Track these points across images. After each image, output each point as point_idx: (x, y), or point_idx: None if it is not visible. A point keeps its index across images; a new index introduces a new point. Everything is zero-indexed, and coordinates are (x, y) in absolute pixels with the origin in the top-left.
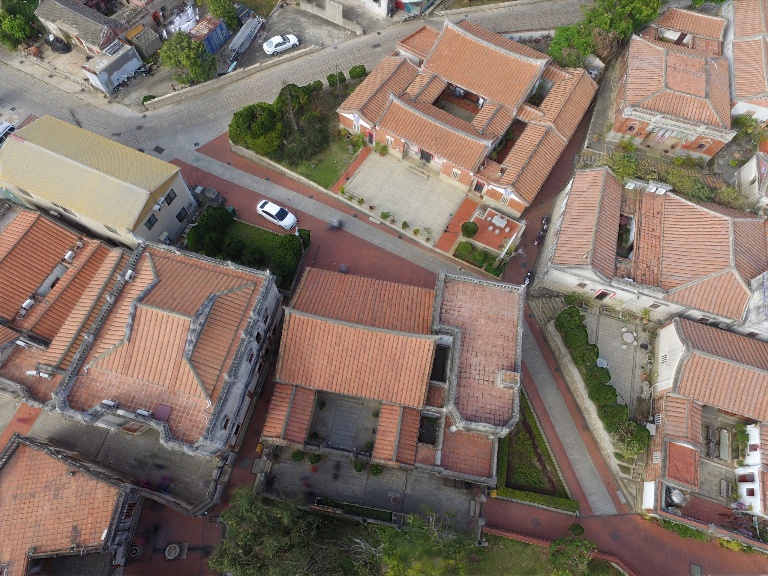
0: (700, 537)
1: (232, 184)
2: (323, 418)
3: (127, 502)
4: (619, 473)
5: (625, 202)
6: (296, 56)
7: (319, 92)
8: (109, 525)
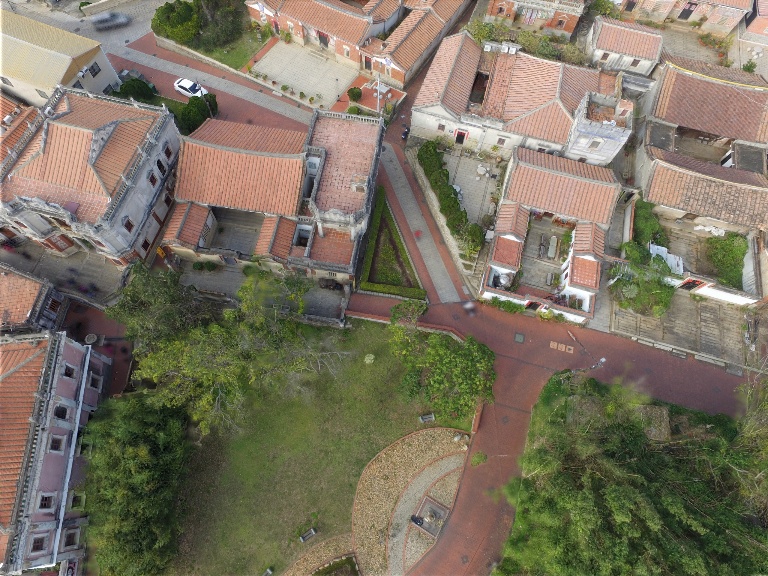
0: (520, 308)
1: (156, 70)
2: (222, 241)
3: (51, 296)
4: (463, 270)
5: (484, 62)
6: None
7: None
8: (33, 305)
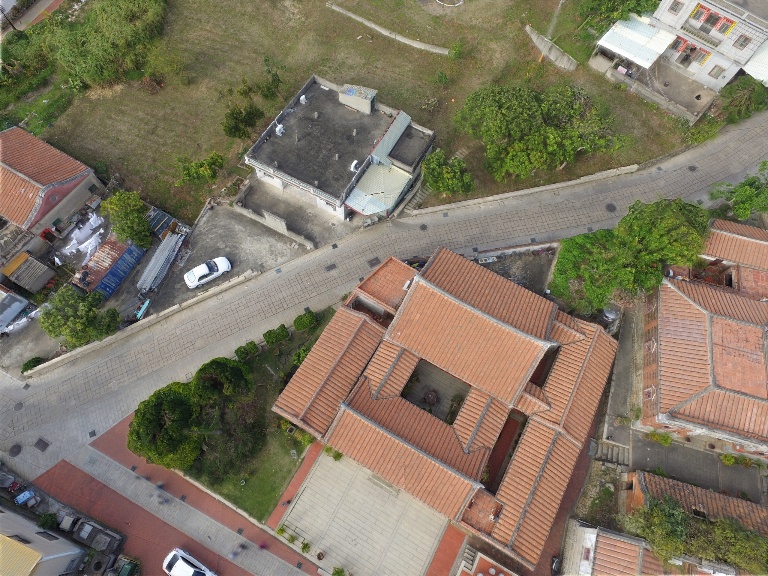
0: None
1: (135, 507)
2: None
3: None
4: None
5: None
6: (227, 288)
7: (254, 355)
8: None
